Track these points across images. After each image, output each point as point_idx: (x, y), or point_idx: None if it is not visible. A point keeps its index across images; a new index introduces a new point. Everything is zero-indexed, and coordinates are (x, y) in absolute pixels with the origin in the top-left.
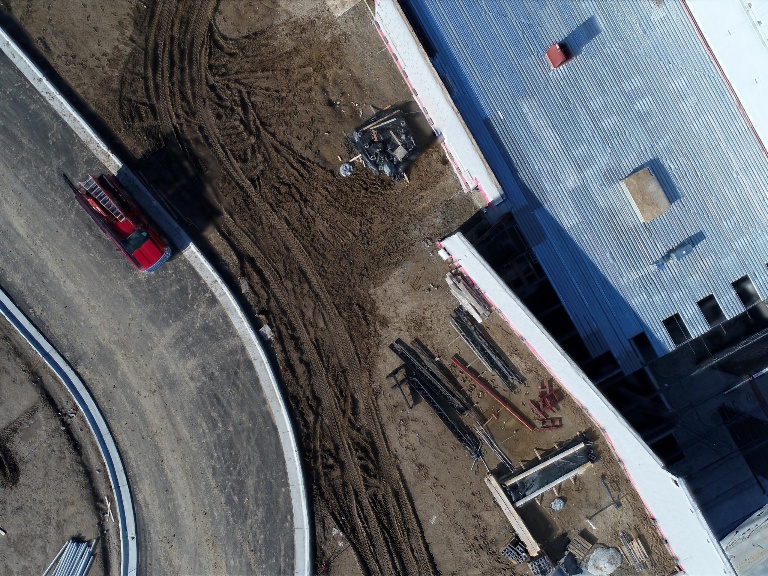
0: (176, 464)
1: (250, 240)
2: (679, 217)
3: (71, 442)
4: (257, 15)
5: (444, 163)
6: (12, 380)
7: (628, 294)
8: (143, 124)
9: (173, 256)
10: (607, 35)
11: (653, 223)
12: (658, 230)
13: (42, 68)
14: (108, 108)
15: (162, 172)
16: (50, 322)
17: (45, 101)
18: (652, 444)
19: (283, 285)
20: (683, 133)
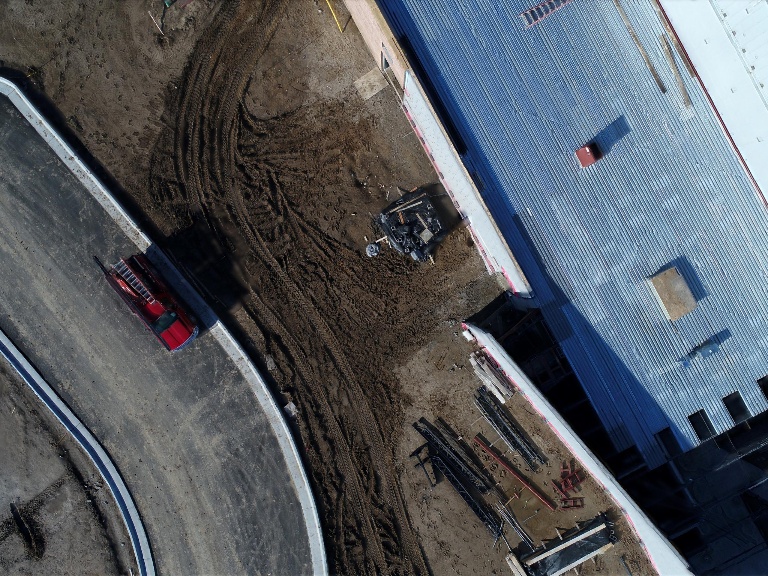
0: (200, 538)
1: (276, 318)
2: (705, 315)
3: (96, 515)
4: (286, 97)
5: (469, 245)
6: (39, 453)
7: (654, 390)
8: (172, 202)
9: (200, 333)
10: (636, 135)
11: (679, 320)
12: (684, 327)
13: (74, 147)
14: (138, 186)
15: (190, 250)
16: (78, 396)
17: (76, 179)
18: (676, 536)
19: (308, 363)
20: (710, 232)
